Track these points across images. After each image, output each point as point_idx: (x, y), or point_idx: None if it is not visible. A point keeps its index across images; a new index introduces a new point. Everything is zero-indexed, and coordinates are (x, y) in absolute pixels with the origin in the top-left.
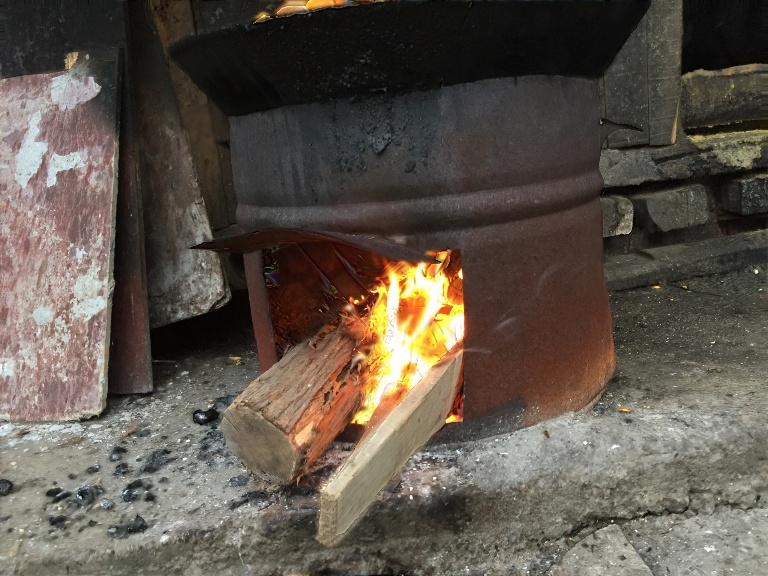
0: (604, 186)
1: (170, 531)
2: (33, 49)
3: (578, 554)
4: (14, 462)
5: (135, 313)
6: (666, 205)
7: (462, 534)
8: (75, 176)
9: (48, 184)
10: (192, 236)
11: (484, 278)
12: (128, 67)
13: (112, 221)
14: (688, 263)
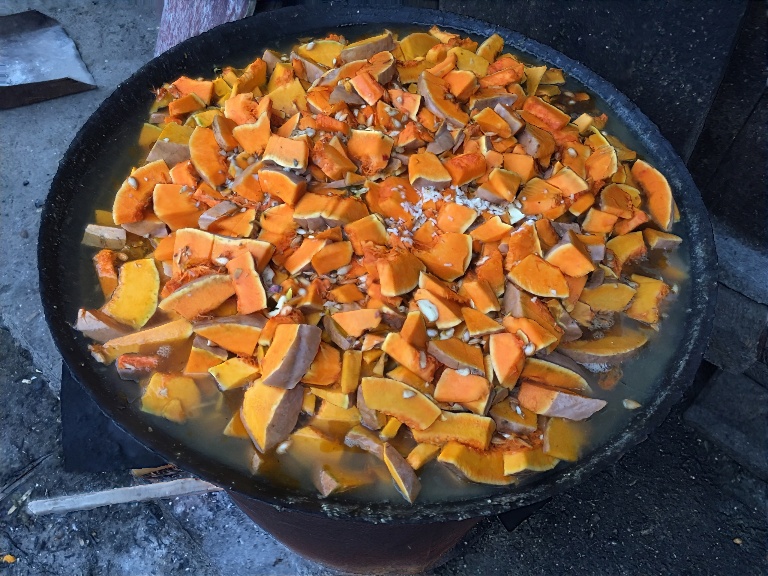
0: None
1: None
2: None
3: None
4: None
5: None
6: None
7: None
8: (226, 6)
9: None
10: None
11: None
12: None
13: None
14: None
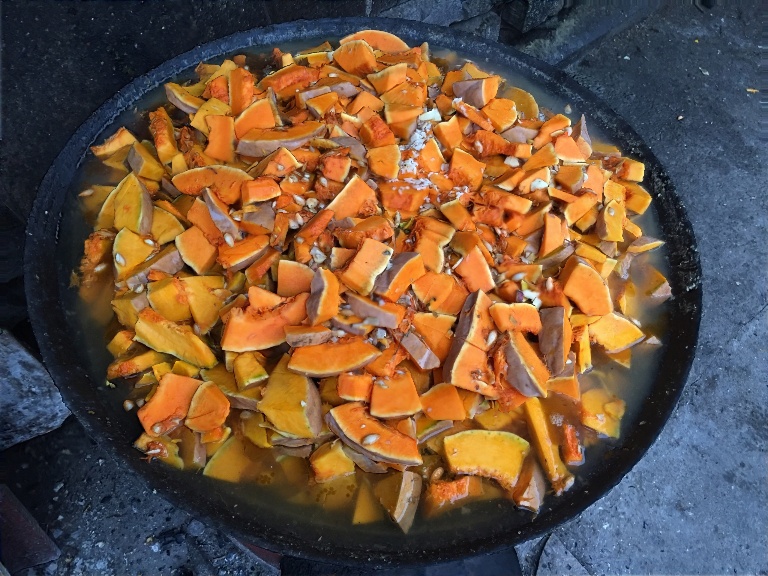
0: None
1: None
2: None
3: None
4: None
5: (2, 513)
6: None
7: None
8: None
9: None
10: (0, 368)
11: None
12: None
13: None
14: None
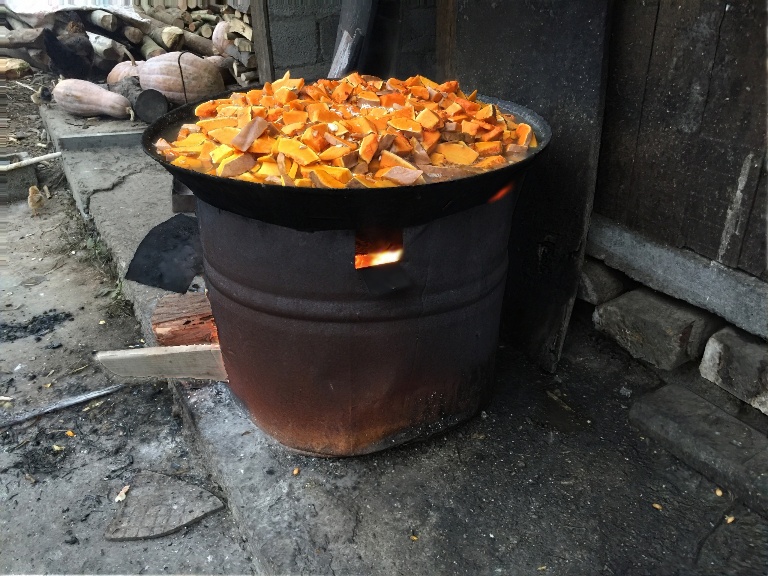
0: (765, 339)
1: None
2: (359, 15)
3: (194, 491)
4: None
5: None
6: None
7: (196, 434)
8: None
9: None
10: None
11: (218, 318)
12: (362, 51)
13: None
14: None
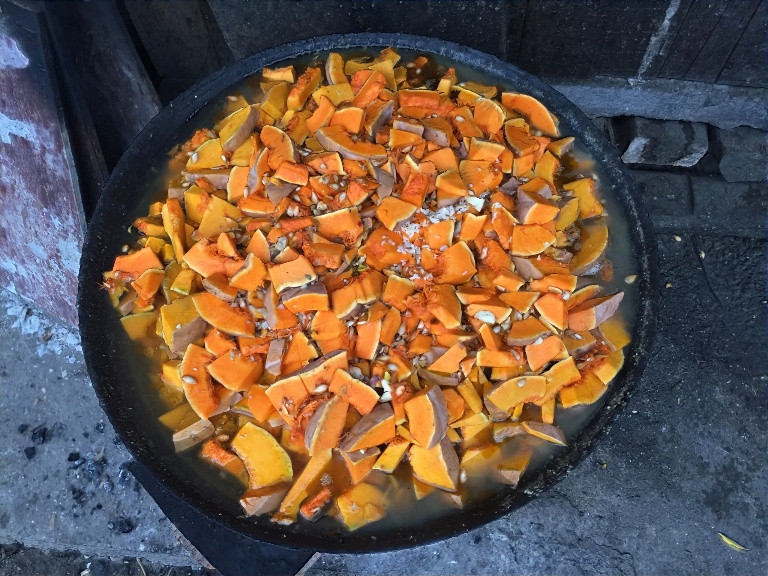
0: (685, 120)
1: (146, 540)
2: None
3: None
4: (44, 388)
5: None
6: (746, 161)
7: (334, 572)
8: (29, 147)
9: (3, 139)
10: None
11: None
12: (55, 36)
13: (78, 208)
14: (727, 228)
